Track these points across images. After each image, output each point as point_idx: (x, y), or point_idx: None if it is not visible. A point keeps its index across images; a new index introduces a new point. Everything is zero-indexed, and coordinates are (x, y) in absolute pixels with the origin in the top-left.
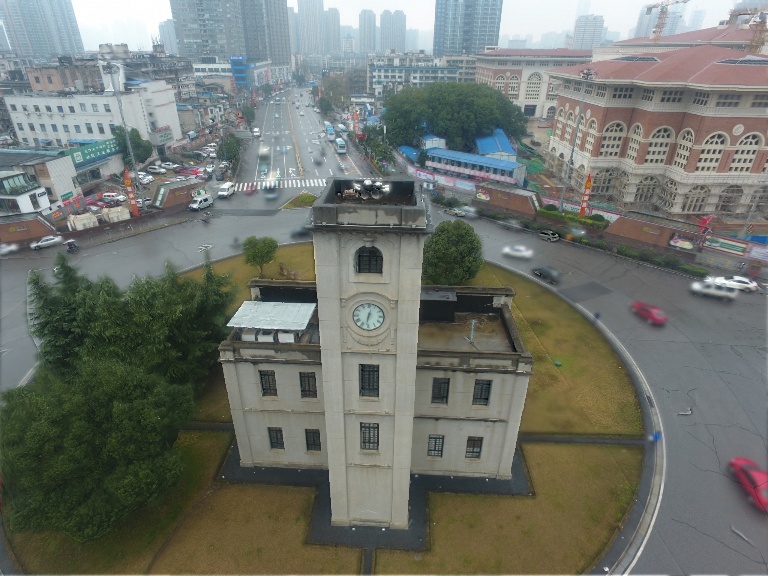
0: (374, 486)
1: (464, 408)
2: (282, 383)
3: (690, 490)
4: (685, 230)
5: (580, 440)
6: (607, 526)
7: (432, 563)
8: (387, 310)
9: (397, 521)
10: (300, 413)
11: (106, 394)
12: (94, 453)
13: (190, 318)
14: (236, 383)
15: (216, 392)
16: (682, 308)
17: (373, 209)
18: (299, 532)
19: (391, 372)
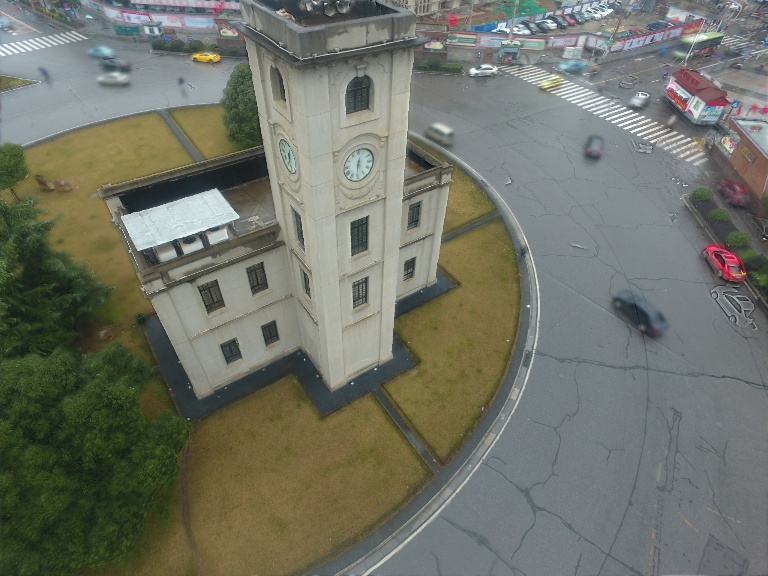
0: (365, 337)
1: (401, 237)
2: (228, 289)
3: (540, 233)
4: (434, 31)
5: (461, 231)
6: (513, 280)
7: (428, 369)
8: (377, 151)
9: (384, 356)
10: (254, 312)
11: (35, 401)
12: (71, 471)
13: (16, 276)
14: (174, 314)
15: (93, 351)
16: (461, 103)
17: (364, 24)
18: (309, 414)
19: (380, 218)
